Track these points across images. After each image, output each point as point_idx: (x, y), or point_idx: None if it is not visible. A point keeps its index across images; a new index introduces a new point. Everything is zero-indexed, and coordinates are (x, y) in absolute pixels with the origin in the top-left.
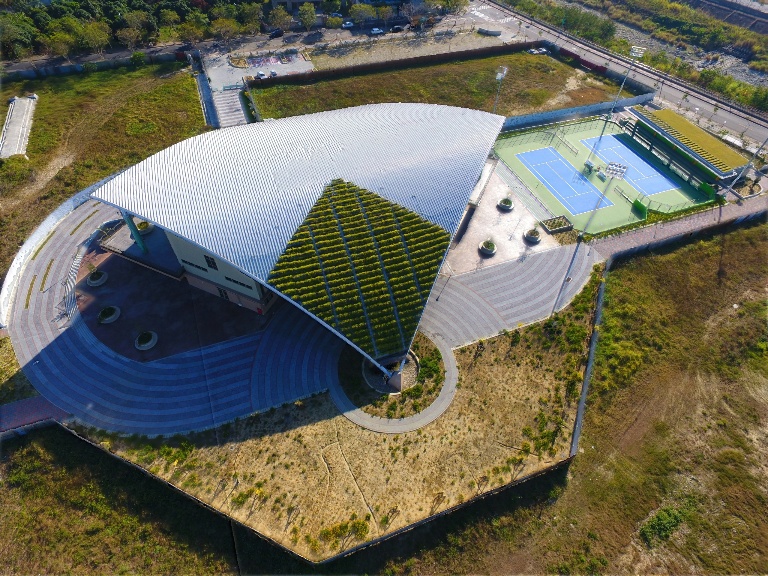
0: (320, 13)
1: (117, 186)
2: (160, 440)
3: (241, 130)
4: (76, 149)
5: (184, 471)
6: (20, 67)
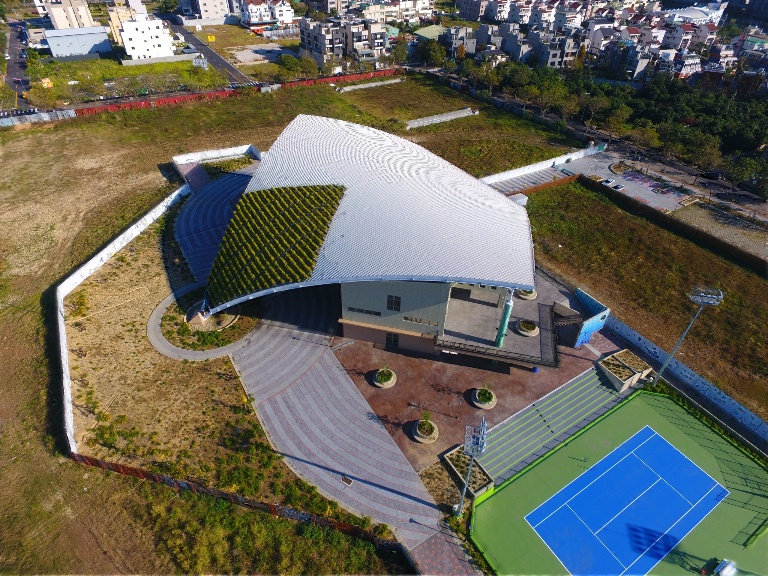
0: None
1: (310, 118)
2: (172, 222)
3: (411, 147)
4: (430, 139)
5: None
6: (507, 100)
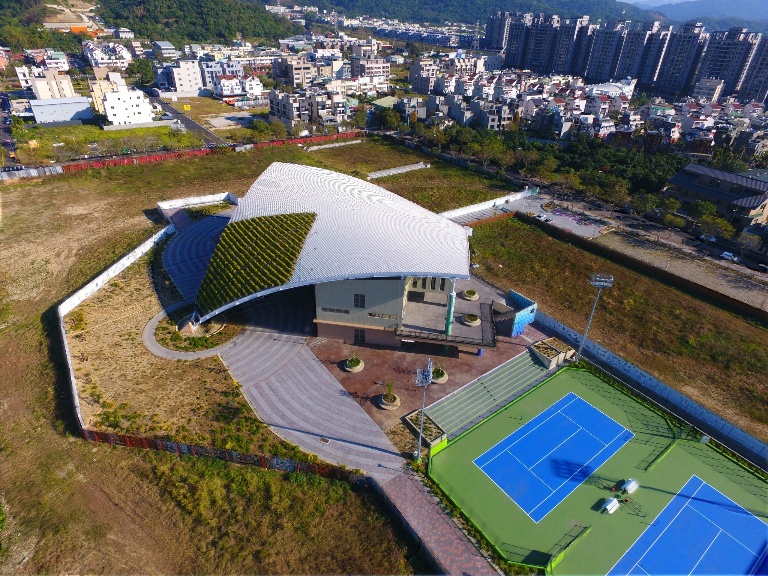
0: (689, 216)
1: None
2: (159, 255)
3: (370, 186)
4: (388, 187)
5: (138, 265)
6: (455, 156)
